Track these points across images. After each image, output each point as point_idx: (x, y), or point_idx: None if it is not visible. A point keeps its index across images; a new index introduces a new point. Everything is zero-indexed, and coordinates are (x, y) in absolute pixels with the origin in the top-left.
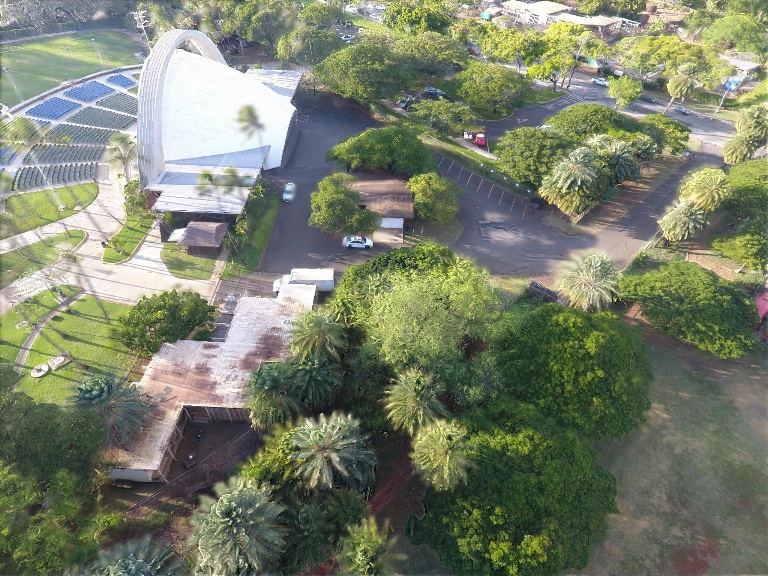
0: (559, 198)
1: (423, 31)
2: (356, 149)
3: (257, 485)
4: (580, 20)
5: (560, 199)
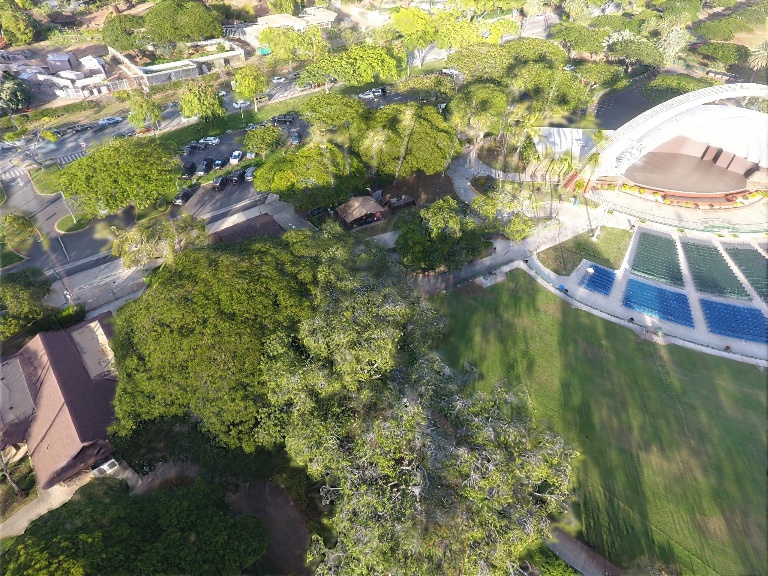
0: None
1: None
2: None
3: None
4: (326, 17)
5: None
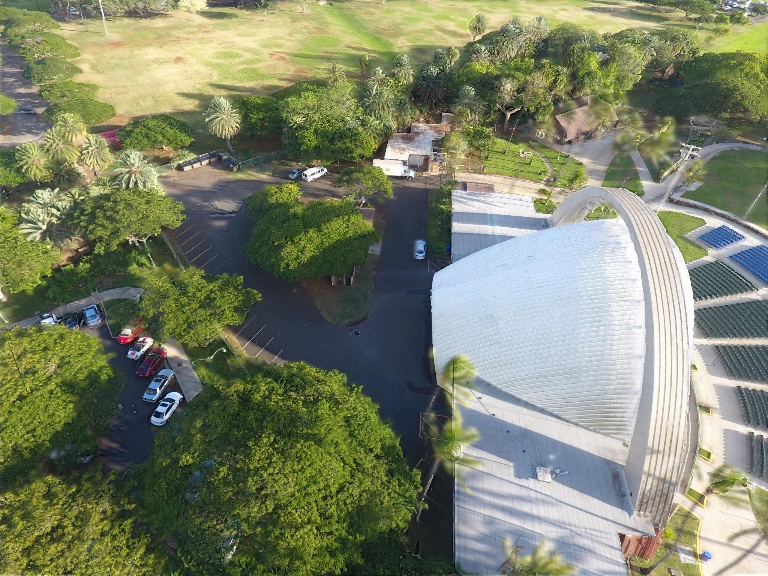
0: None
1: None
2: (346, 204)
3: None
4: None
5: None
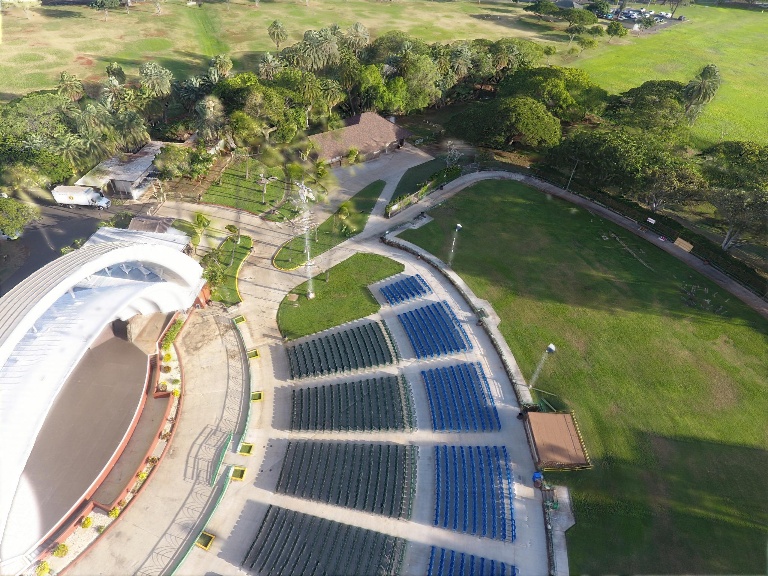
0: None
1: None
2: None
3: None
4: None
5: None
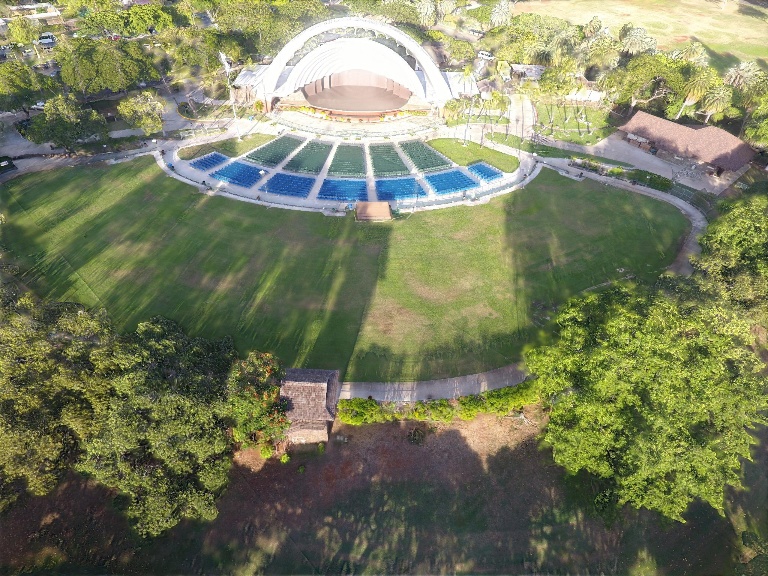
0: (429, 20)
1: (171, 20)
2: None
3: (622, 40)
4: None
5: (429, 21)
